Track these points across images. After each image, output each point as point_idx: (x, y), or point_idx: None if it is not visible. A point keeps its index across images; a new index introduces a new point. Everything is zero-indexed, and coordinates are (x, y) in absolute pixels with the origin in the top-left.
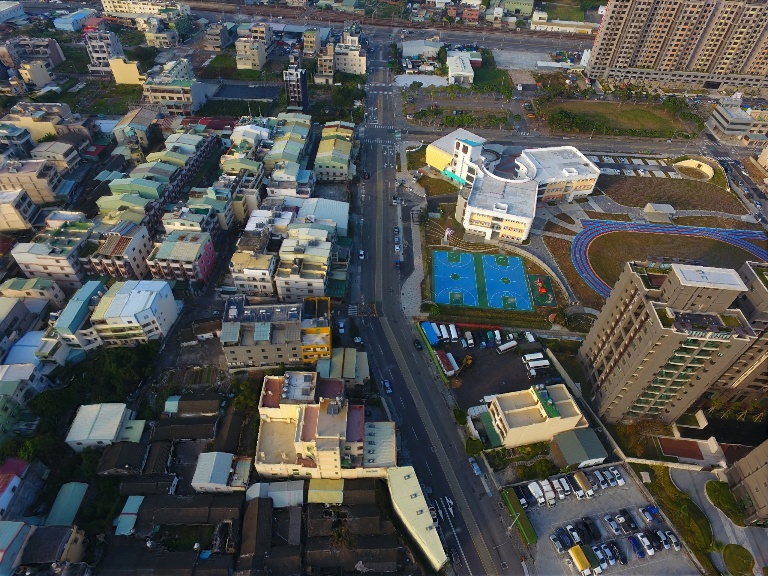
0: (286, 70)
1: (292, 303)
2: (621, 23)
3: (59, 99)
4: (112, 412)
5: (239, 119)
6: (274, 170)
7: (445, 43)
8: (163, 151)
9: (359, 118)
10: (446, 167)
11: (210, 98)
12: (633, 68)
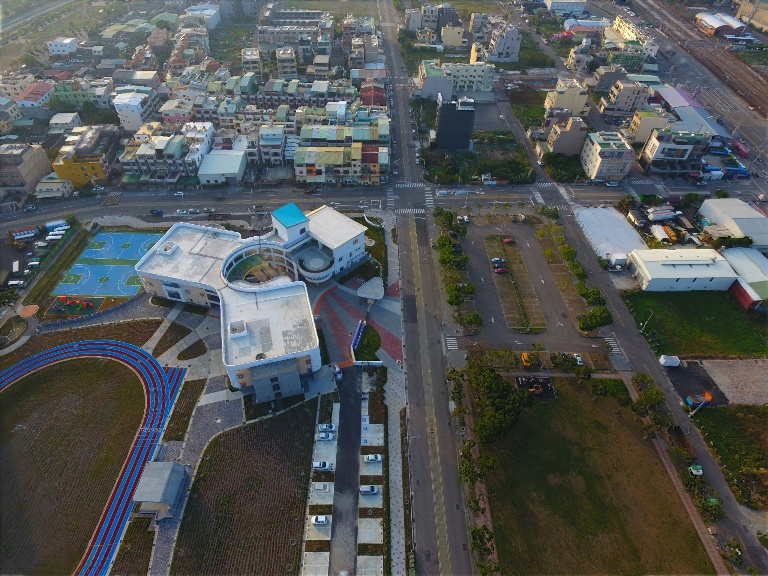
0: None
1: (101, 149)
2: None
3: (428, 54)
4: (66, 119)
5: (379, 106)
6: None
7: None
8: (298, 81)
9: (444, 181)
10: None
11: None
12: None
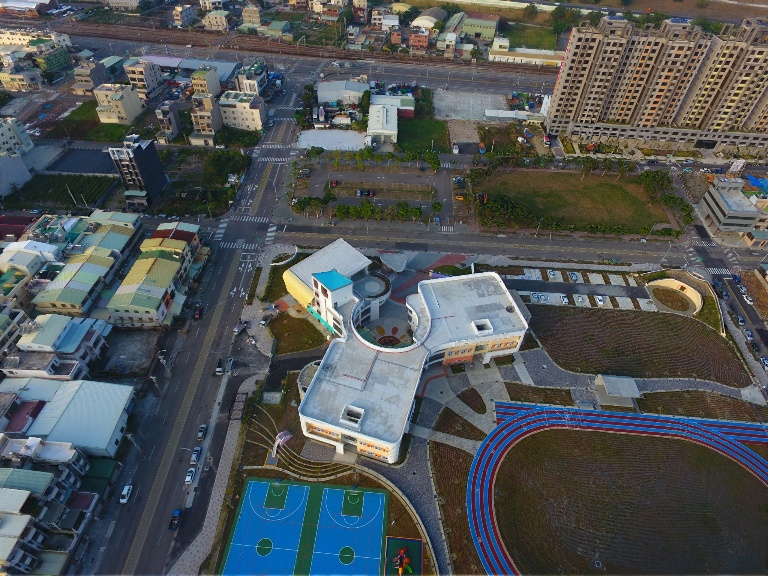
0: (159, 126)
1: None
2: (586, 68)
3: None
4: None
5: (36, 221)
6: (21, 334)
7: (377, 82)
8: None
9: (226, 204)
10: (309, 305)
11: (39, 172)
12: (603, 123)
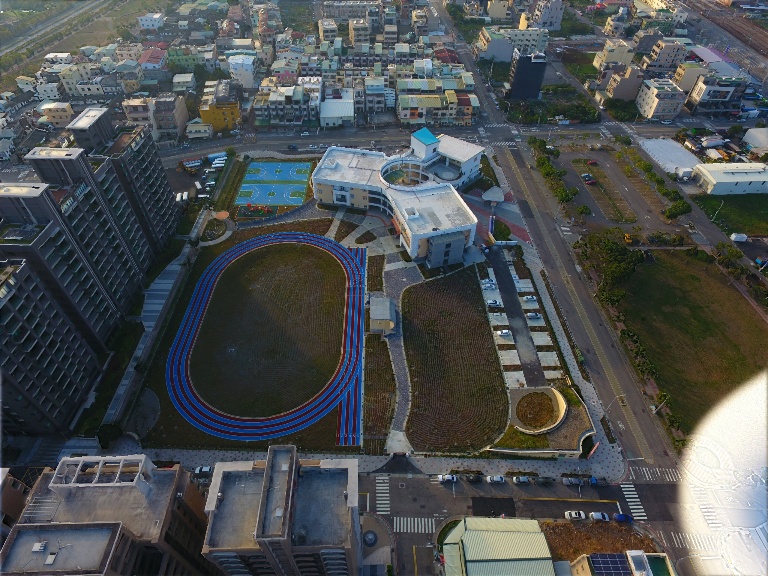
0: None
1: None
2: None
3: (478, 25)
4: None
5: (456, 63)
6: None
7: None
8: None
9: (525, 121)
10: None
11: None
12: None
